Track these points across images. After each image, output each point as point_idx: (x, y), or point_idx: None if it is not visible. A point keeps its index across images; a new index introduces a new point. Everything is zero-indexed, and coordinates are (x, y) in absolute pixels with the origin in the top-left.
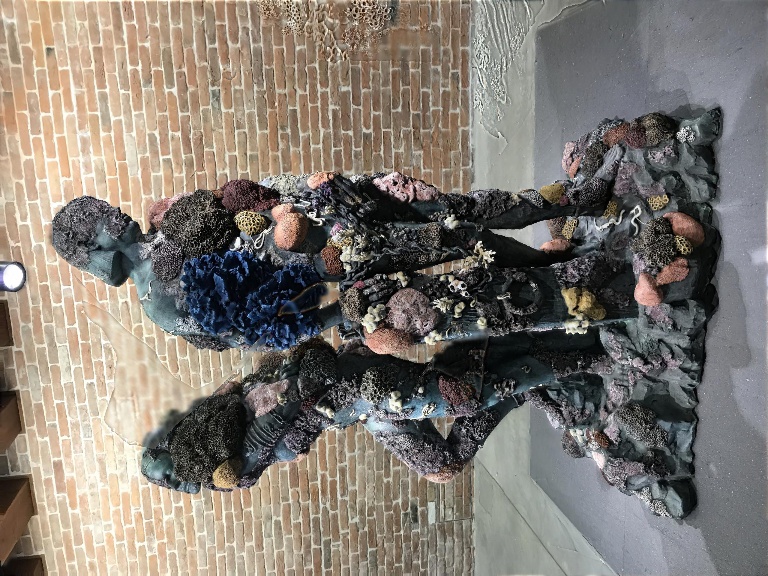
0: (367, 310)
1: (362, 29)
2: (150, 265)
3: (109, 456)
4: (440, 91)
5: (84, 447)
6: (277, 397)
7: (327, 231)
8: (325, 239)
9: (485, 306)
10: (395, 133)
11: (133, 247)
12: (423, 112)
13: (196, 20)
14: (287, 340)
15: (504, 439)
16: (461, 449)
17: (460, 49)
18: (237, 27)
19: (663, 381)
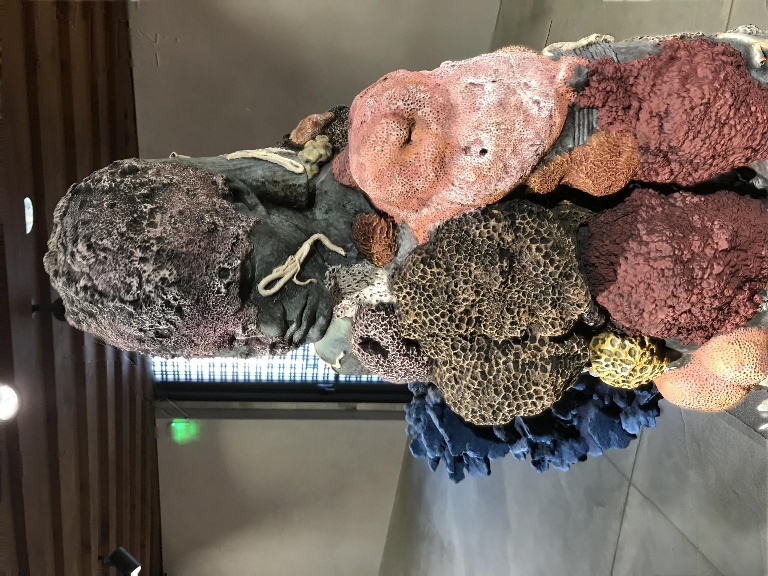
0: None
1: None
2: (343, 327)
3: None
4: None
5: None
6: None
7: None
8: None
9: None
10: None
11: None
12: None
13: None
14: None
15: None
16: None
17: None
18: None
19: None
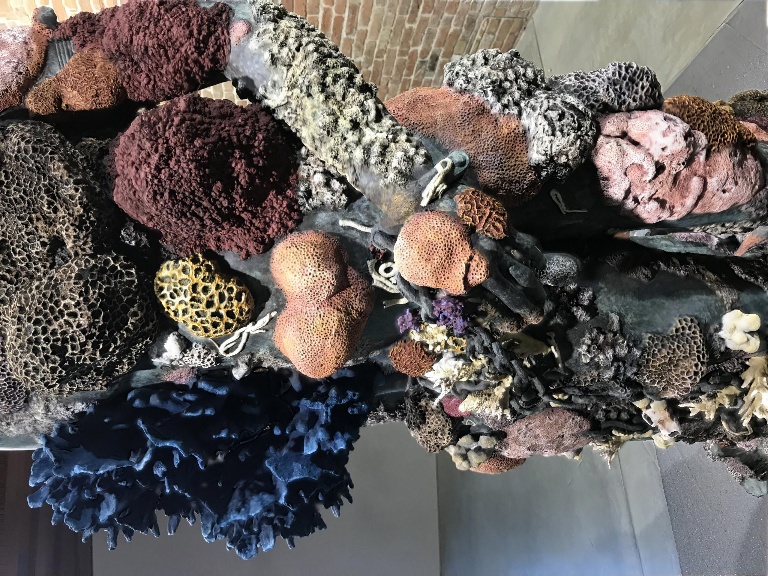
0: (459, 438)
1: None
2: None
3: None
4: None
5: None
6: None
7: None
8: None
9: (689, 425)
10: None
11: None
12: None
13: None
14: None
15: (580, 50)
16: None
17: None
18: None
19: None
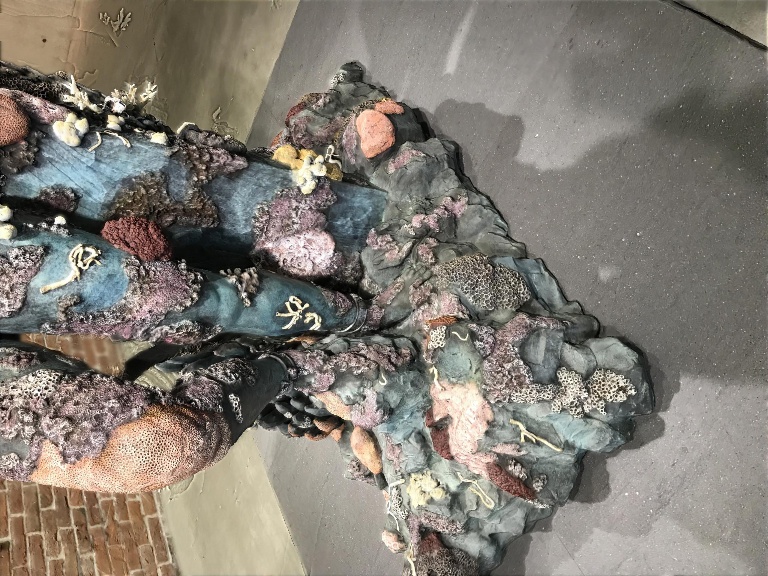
0: None
1: None
2: None
3: None
4: None
5: None
6: None
7: None
8: None
9: None
10: (48, 536)
11: None
12: (88, 505)
13: None
14: None
15: None
16: (189, 391)
17: None
18: None
19: (467, 244)
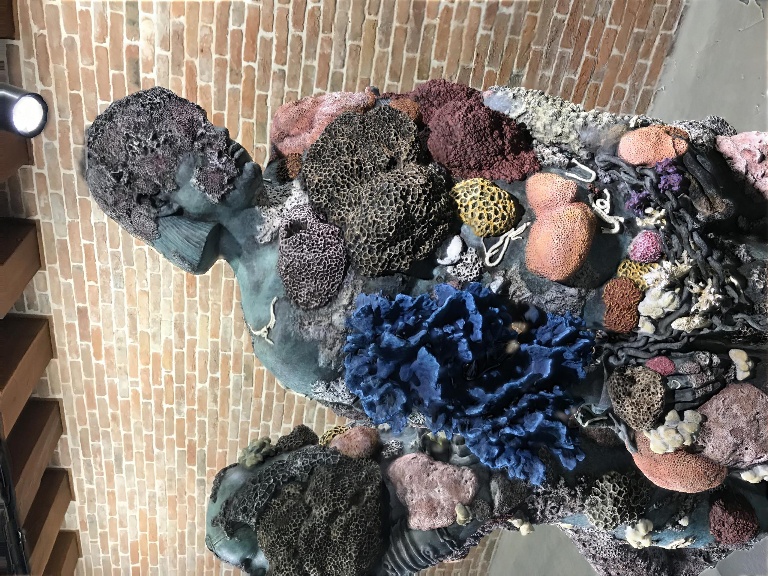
0: (665, 416)
1: None
2: (274, 258)
3: (142, 312)
4: None
5: (114, 299)
6: (456, 511)
7: (623, 245)
8: (616, 261)
9: None
10: None
11: (245, 216)
12: None
13: None
14: (525, 475)
15: None
16: (686, 571)
17: None
18: None
19: None
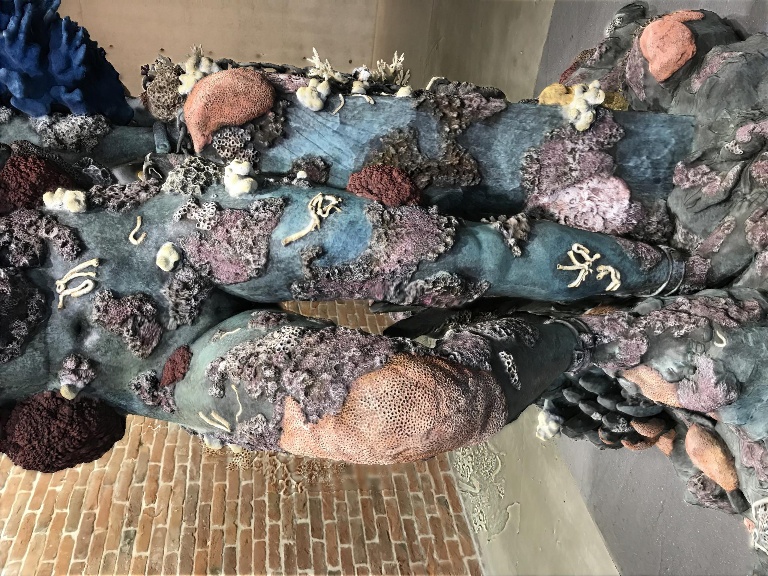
0: None
1: (321, 461)
2: None
3: None
4: (426, 518)
5: None
6: None
7: None
8: None
9: None
10: (374, 569)
11: None
12: (409, 541)
13: (126, 461)
14: (14, 16)
15: None
16: (447, 345)
17: (441, 474)
18: (173, 465)
19: None
